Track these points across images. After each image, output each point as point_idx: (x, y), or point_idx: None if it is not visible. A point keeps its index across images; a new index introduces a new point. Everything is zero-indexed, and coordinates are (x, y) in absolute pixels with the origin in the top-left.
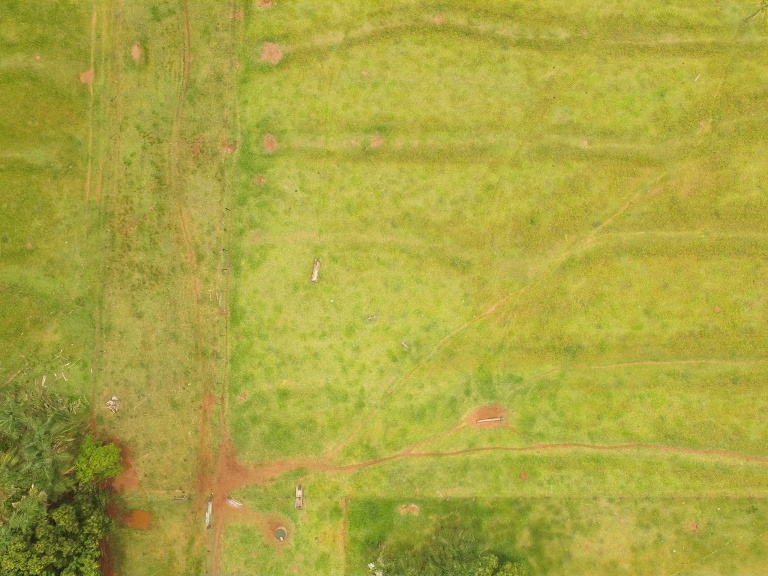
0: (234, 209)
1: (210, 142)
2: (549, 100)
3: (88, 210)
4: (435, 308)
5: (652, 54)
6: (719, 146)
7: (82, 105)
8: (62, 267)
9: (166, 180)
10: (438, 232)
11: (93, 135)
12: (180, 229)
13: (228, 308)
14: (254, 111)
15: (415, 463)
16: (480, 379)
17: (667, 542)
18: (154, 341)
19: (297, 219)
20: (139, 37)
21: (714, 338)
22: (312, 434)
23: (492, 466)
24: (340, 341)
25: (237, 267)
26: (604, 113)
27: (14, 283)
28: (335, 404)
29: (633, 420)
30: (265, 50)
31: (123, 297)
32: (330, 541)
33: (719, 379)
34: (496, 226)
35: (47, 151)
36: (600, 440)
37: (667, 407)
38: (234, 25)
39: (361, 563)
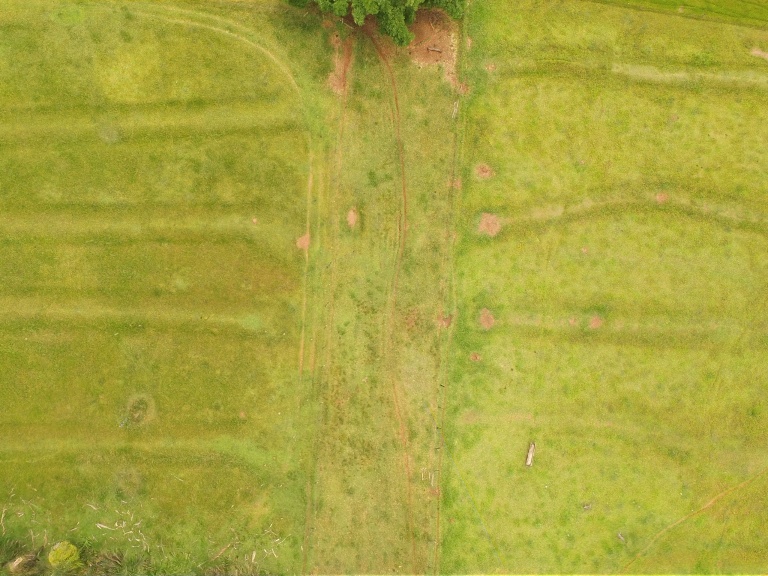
0: (448, 386)
1: (425, 314)
2: None
3: (301, 380)
4: (652, 500)
5: None
6: None
7: (297, 270)
8: (274, 439)
9: (379, 352)
10: (656, 420)
11: (307, 302)
12: (392, 403)
13: (440, 489)
14: (470, 284)
15: None
16: None
17: None
18: (365, 519)
19: (512, 399)
20: (355, 202)
21: None
22: None
23: None
24: (554, 529)
25: (450, 446)
26: None
27: (225, 452)
28: None
29: None
30: (482, 221)
31: (334, 472)
32: None
33: None
34: (715, 416)
35: (261, 317)
36: None
37: None
38: (452, 194)
39: None
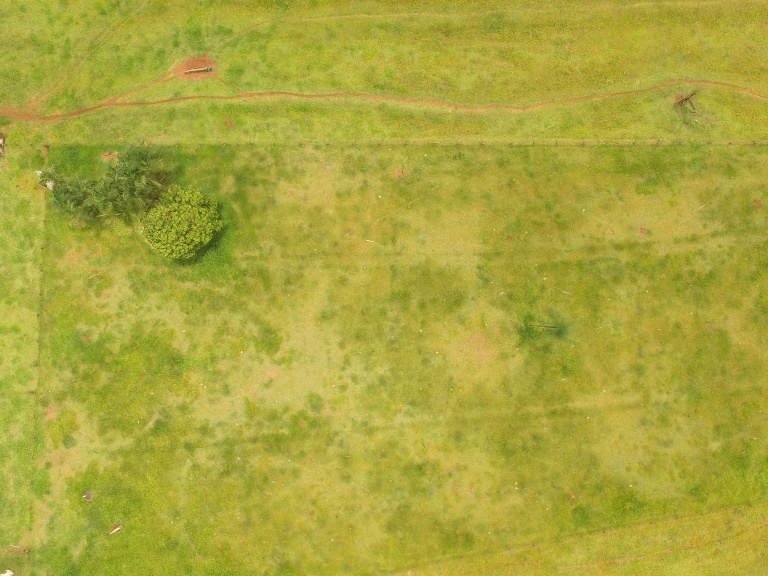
0: None
1: None
2: None
3: None
4: None
5: None
6: None
7: None
8: None
9: None
10: None
11: None
12: None
13: None
14: None
15: (120, 112)
16: (188, 30)
17: (373, 188)
18: None
19: None
20: None
21: None
22: (15, 83)
23: (198, 115)
24: None
25: None
26: None
27: None
28: (41, 55)
29: (343, 71)
30: None
31: None
32: (31, 188)
33: (432, 32)
34: None
35: None
36: (308, 89)
37: (378, 59)
38: None
39: (61, 209)
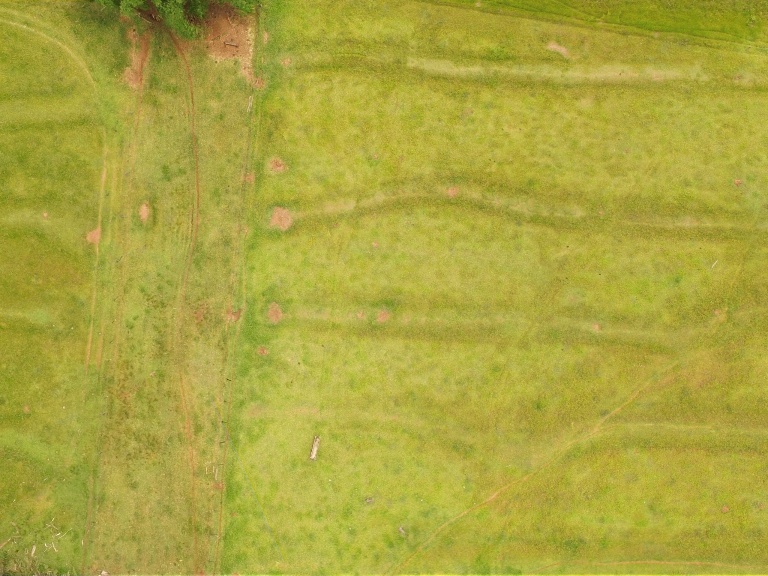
0: (235, 380)
1: (214, 308)
2: (561, 281)
3: (87, 374)
4: (435, 493)
5: (669, 237)
6: (734, 337)
7: (87, 264)
8: (58, 433)
9: (168, 346)
10: (442, 413)
11: (97, 296)
12: (179, 397)
13: (224, 482)
14: (260, 278)
15: None
16: (478, 571)
17: None
18: (147, 513)
19: (299, 393)
20: (148, 196)
21: (720, 539)
22: None
23: None
24: (336, 523)
25: (235, 440)
26: (617, 297)
27: (9, 447)
28: None
29: None
30: (275, 215)
31: (118, 466)
32: None
33: None
34: (501, 409)
35: (49, 311)
36: None
37: None
38: (244, 189)
39: None
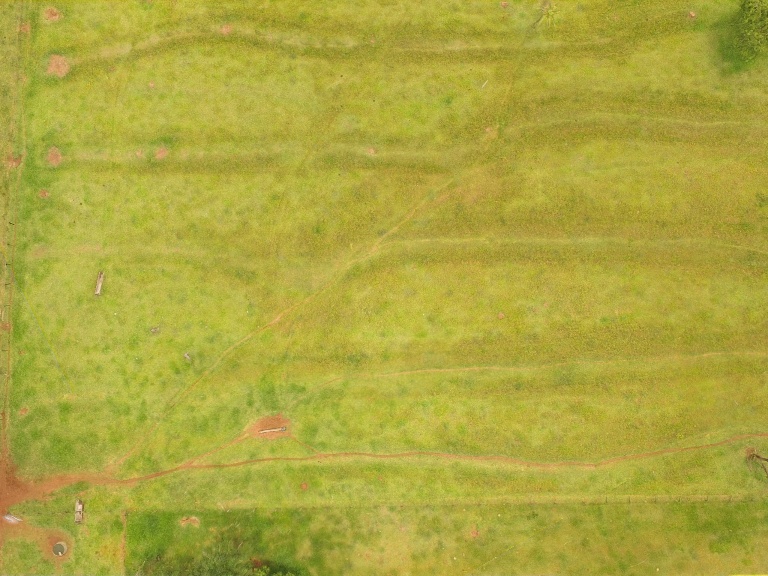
0: (18, 223)
1: None
2: (336, 109)
3: None
4: (219, 319)
5: (440, 61)
6: (505, 152)
7: None
8: None
9: None
10: (223, 243)
11: None
12: None
13: (11, 323)
14: (40, 124)
15: (196, 475)
16: (262, 390)
17: (448, 549)
18: None
19: (81, 232)
20: None
21: (497, 344)
22: (93, 448)
23: (274, 477)
24: (123, 354)
25: (21, 281)
26: (391, 121)
27: None
28: (117, 417)
29: (415, 428)
30: (52, 63)
31: None
32: (110, 555)
33: (502, 385)
34: (282, 236)
35: None
36: (382, 449)
37: (450, 414)
38: (20, 38)
39: None
